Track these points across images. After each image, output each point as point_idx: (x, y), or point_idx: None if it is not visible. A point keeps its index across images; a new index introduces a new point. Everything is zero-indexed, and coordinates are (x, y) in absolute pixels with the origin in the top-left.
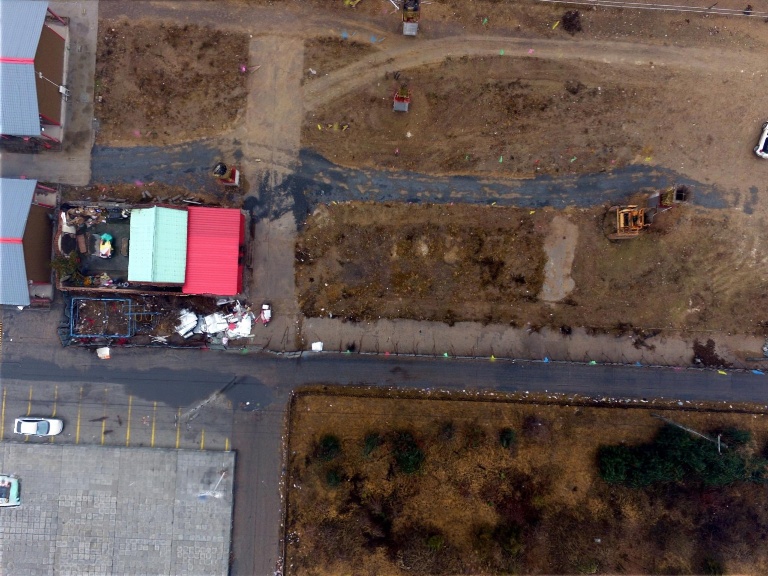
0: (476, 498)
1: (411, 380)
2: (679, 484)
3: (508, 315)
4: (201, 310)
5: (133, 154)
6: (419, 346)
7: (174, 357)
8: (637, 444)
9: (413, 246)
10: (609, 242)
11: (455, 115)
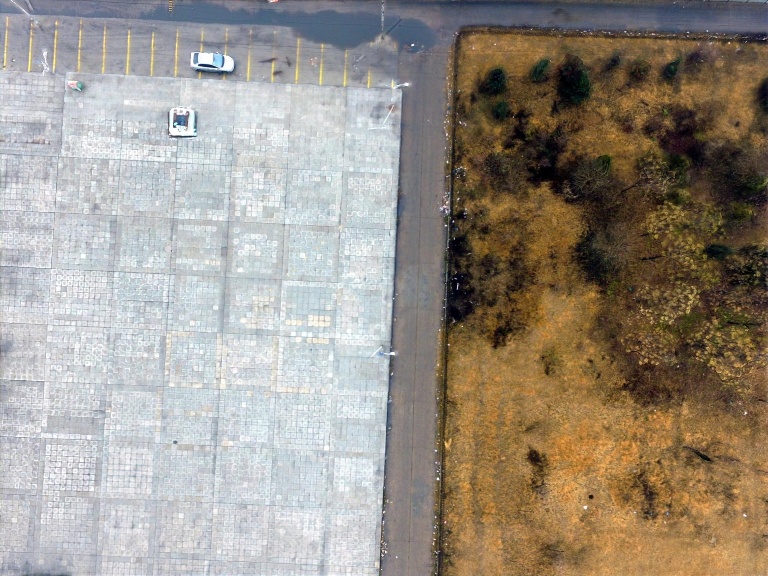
0: (639, 134)
1: (573, 22)
2: None
3: None
4: None
5: None
6: None
7: (340, 0)
8: None
9: None
10: None
11: None
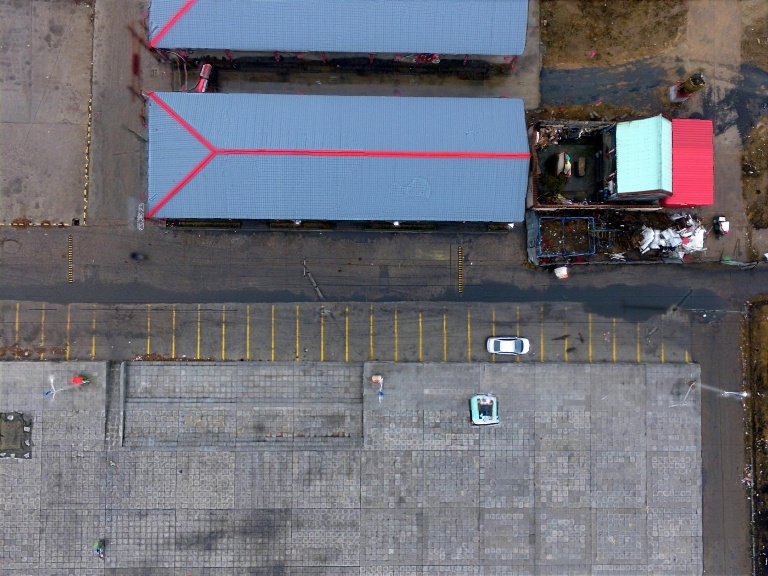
0: None
1: None
2: None
3: None
4: (656, 226)
5: (580, 76)
6: None
7: (630, 273)
8: None
9: None
10: None
11: None
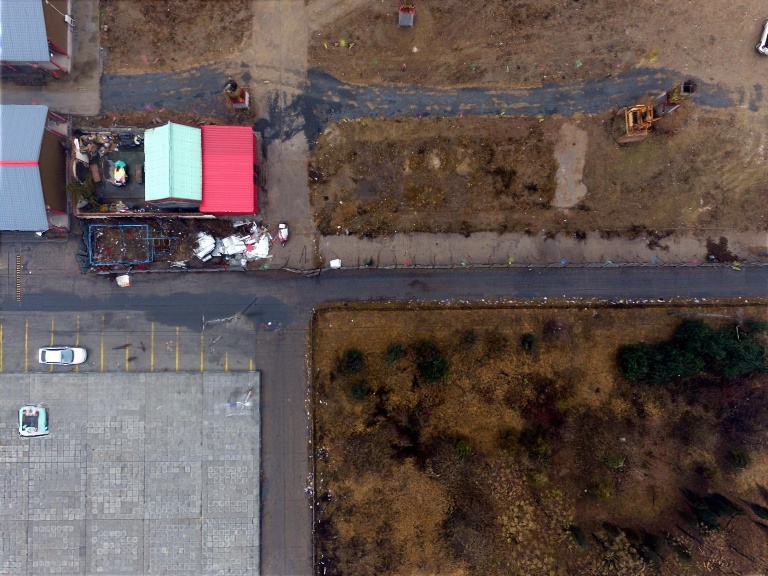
0: (501, 404)
1: (430, 292)
2: (700, 375)
3: (523, 223)
4: (218, 233)
5: (142, 81)
6: (436, 258)
7: (194, 281)
8: (656, 342)
9: (425, 160)
10: (618, 146)
11: (460, 28)
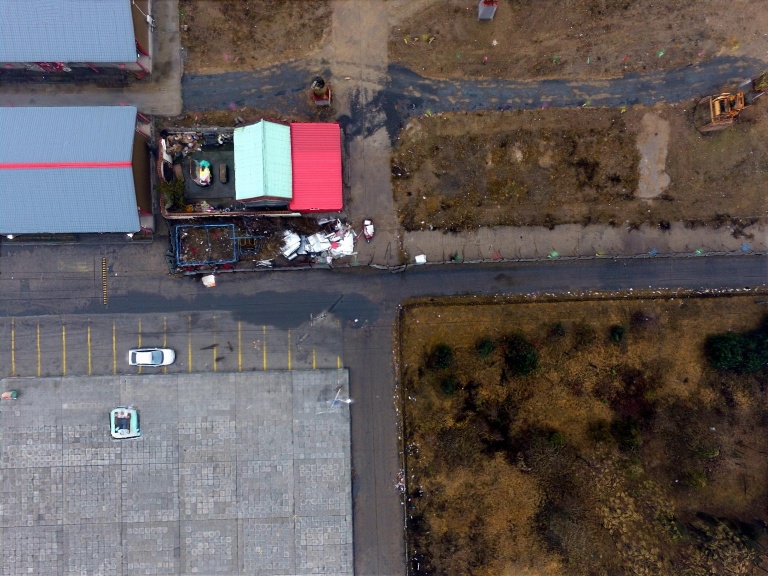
0: (589, 397)
1: (516, 286)
2: None
3: (607, 214)
4: (303, 231)
5: (223, 81)
6: (521, 251)
7: (279, 280)
8: (744, 331)
9: (507, 153)
10: (701, 135)
11: (539, 20)
